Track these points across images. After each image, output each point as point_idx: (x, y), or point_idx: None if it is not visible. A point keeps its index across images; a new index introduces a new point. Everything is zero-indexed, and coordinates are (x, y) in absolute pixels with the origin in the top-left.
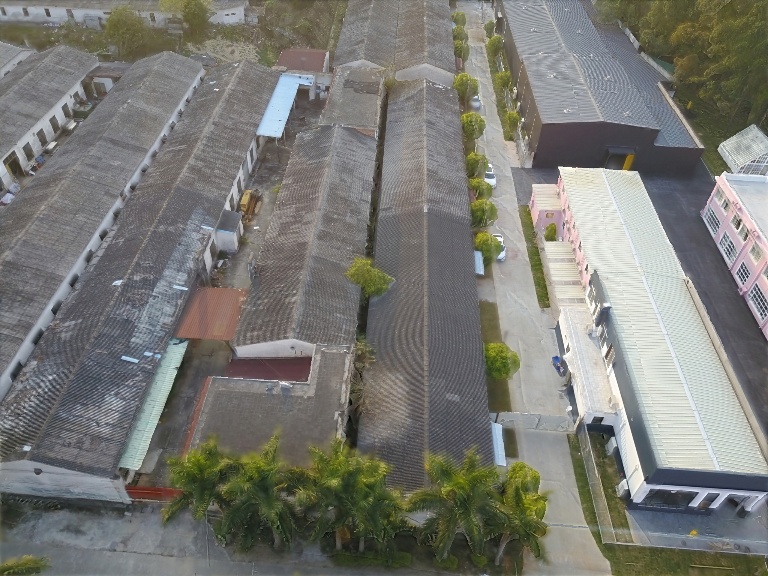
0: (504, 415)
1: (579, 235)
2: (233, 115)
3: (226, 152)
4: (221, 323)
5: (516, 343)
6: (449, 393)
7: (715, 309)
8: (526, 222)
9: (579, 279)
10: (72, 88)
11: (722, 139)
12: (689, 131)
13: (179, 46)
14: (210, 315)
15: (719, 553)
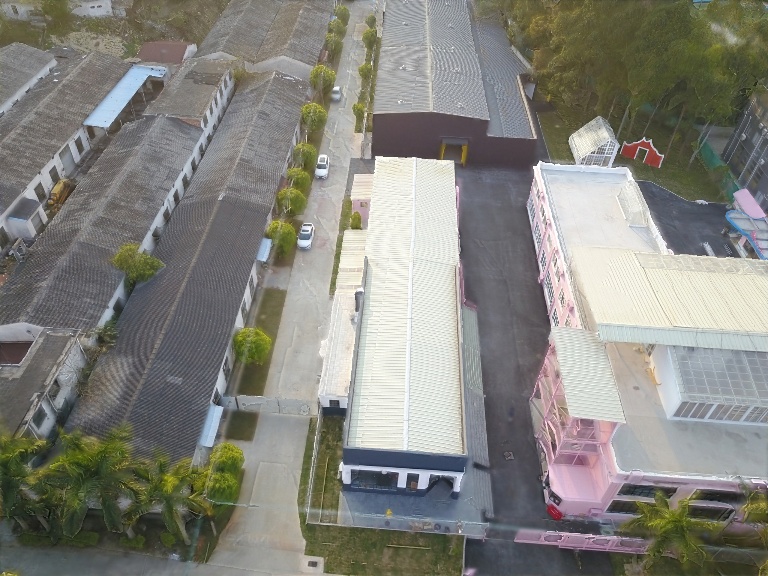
0: (242, 399)
1: (368, 223)
2: (62, 105)
3: (41, 141)
4: None
5: (292, 329)
6: (171, 376)
7: (509, 297)
8: (346, 211)
9: None
10: None
11: None
12: (530, 122)
13: (42, 38)
14: None
15: (419, 533)
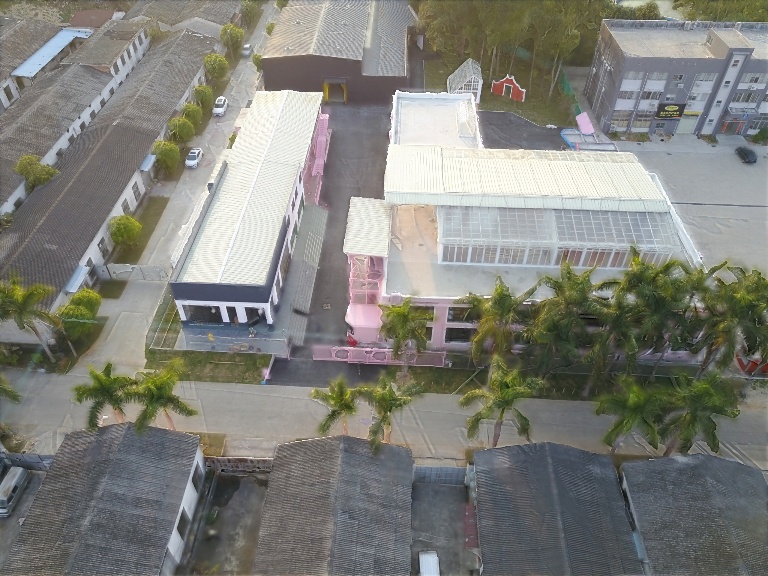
0: (112, 267)
1: None
2: None
3: None
4: None
5: (168, 224)
6: (48, 244)
7: None
8: None
9: None
10: None
11: None
12: (405, 64)
13: None
14: None
15: (236, 353)
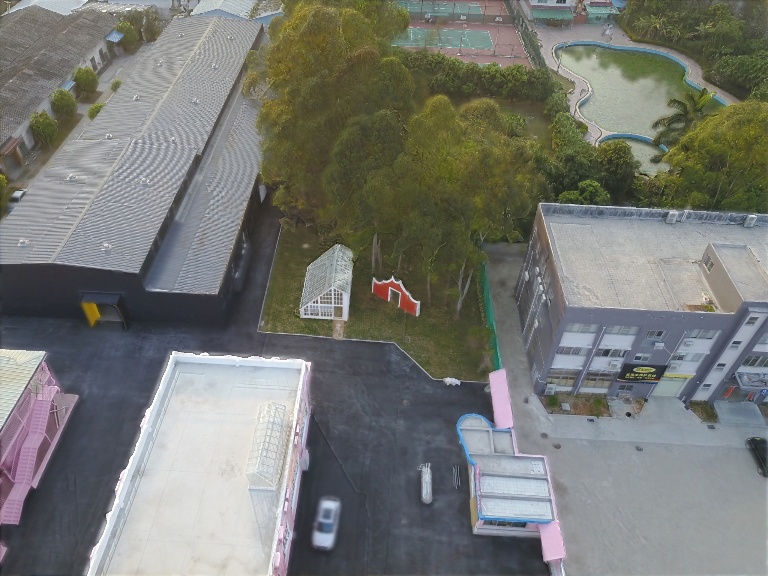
0: None
1: None
2: None
3: None
4: None
5: None
6: None
7: None
8: None
9: None
10: None
11: None
12: None
13: None
14: None
15: None
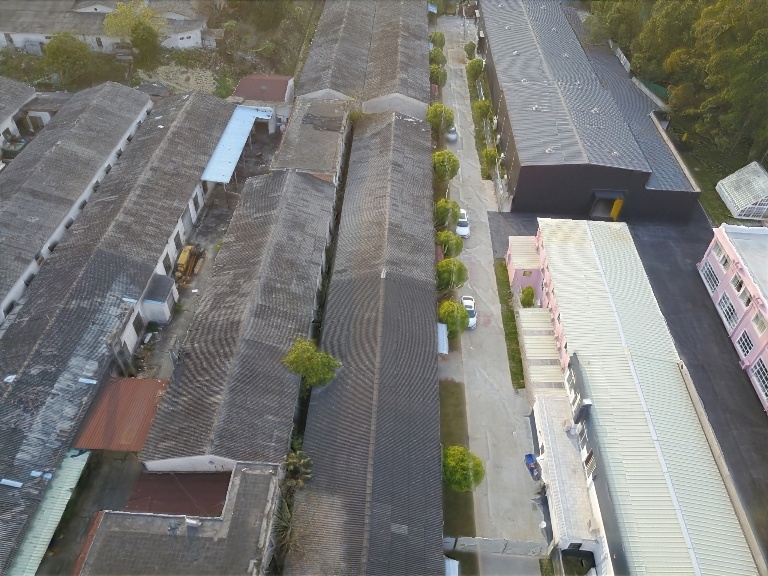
0: (464, 540)
1: (558, 305)
2: (176, 158)
3: (163, 203)
4: (131, 427)
5: (484, 436)
6: (395, 523)
7: (713, 387)
8: (502, 279)
9: (558, 357)
10: (1, 125)
11: (720, 175)
12: (684, 170)
13: (129, 73)
14: (120, 416)
15: None
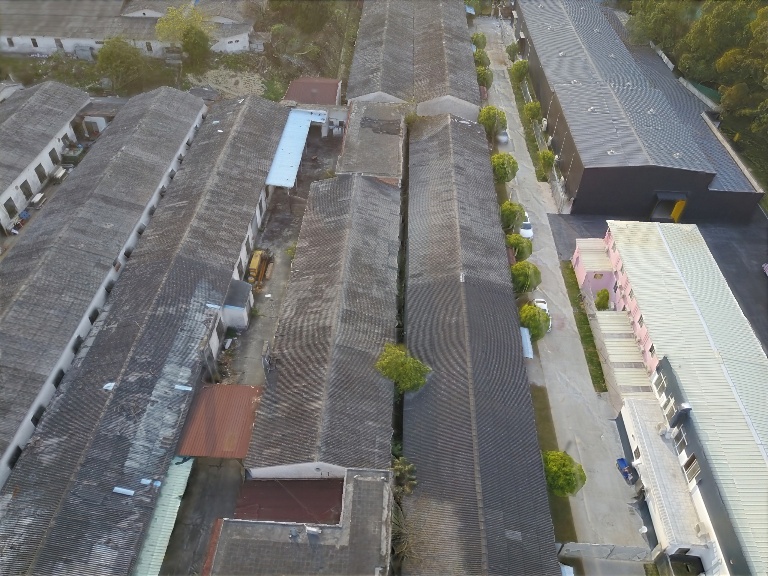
0: (570, 546)
1: (640, 308)
2: (239, 162)
3: (233, 208)
4: (232, 434)
5: (573, 440)
6: (509, 529)
7: None
8: (570, 282)
9: (641, 360)
10: (60, 131)
11: None
12: (744, 171)
13: (178, 77)
14: (219, 423)
15: None
